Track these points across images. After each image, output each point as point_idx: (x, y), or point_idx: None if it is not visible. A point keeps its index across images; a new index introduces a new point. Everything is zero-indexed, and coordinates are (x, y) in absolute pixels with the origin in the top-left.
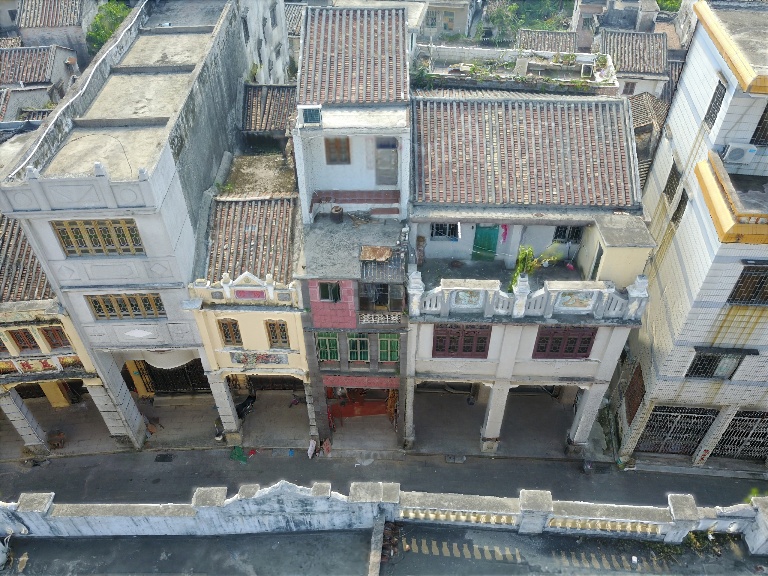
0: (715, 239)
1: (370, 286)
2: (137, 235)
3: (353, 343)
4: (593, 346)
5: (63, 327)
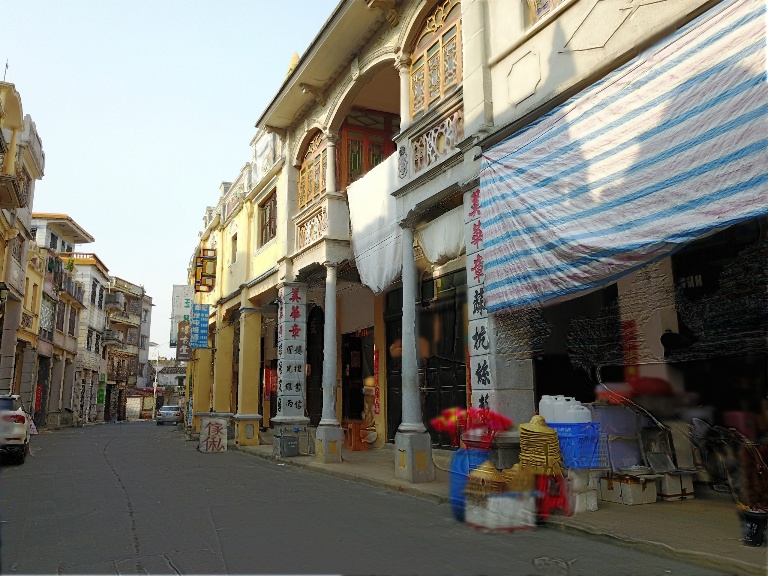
0: (84, 270)
1: (57, 264)
2: (26, 192)
3: (45, 312)
4: (74, 327)
5: (4, 252)
